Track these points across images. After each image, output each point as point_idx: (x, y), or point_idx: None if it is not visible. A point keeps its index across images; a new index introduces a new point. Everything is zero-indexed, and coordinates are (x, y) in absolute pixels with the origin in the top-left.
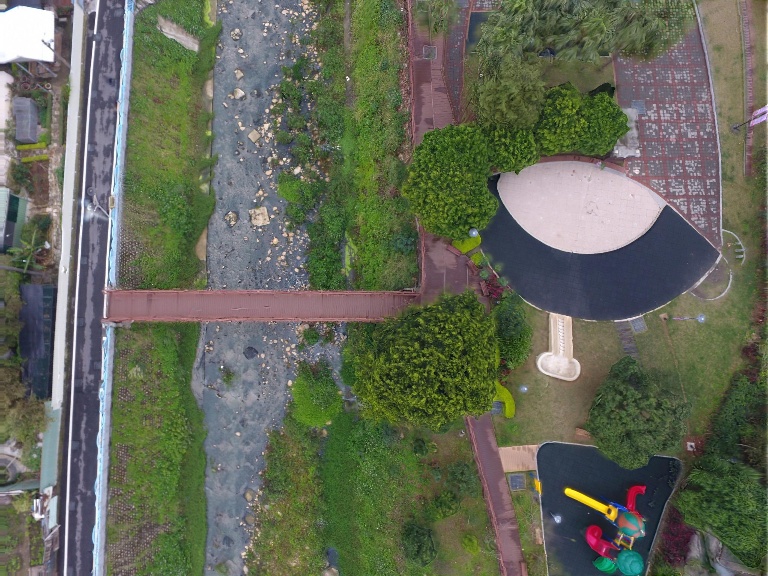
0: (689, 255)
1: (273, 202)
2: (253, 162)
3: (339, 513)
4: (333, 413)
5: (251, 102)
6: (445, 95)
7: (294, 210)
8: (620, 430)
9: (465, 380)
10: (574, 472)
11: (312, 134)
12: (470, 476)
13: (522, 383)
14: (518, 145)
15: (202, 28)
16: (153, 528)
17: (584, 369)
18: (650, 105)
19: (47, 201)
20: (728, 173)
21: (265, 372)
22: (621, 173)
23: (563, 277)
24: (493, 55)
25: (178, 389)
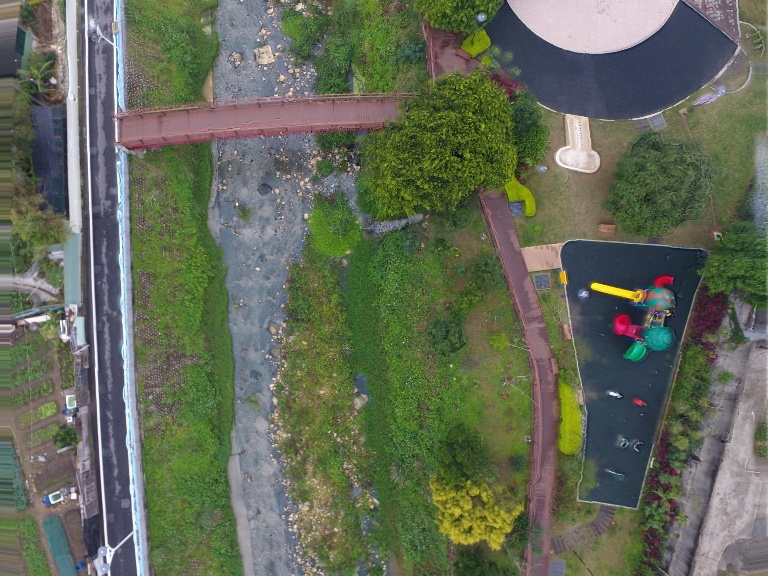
0: (706, 49)
1: (276, 41)
2: (253, 2)
3: (364, 339)
4: (351, 242)
5: None
6: None
7: (298, 43)
8: (645, 193)
9: (484, 140)
10: (599, 268)
11: None
12: (494, 267)
13: (541, 181)
14: None
15: None
16: (180, 358)
17: (604, 162)
18: None
19: (51, 39)
20: None
21: (280, 208)
22: None
23: (577, 79)
24: None
25: (195, 226)
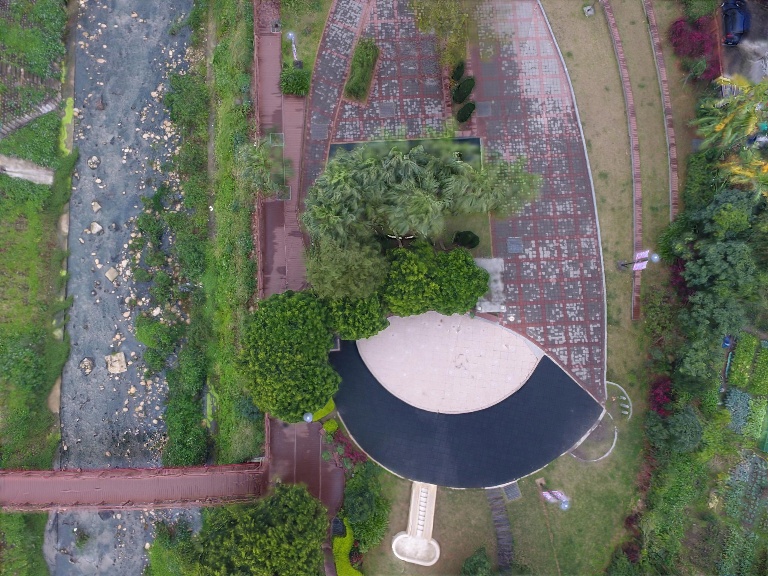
0: (569, 412)
1: (132, 346)
2: (110, 303)
3: None
4: None
5: (109, 236)
6: (300, 240)
7: (150, 358)
8: None
9: None
10: None
11: (173, 270)
12: None
13: (378, 566)
14: (358, 316)
15: (56, 158)
16: None
17: (445, 550)
18: (528, 242)
19: None
20: (614, 316)
21: (121, 534)
22: (493, 322)
23: (428, 440)
24: (314, 232)
25: (26, 557)
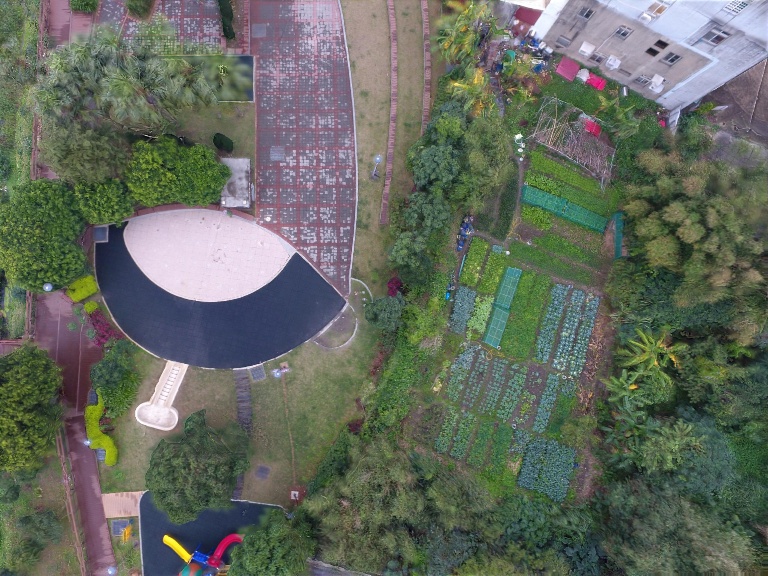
0: (314, 303)
1: None
2: None
3: None
4: None
5: None
6: None
7: None
8: (156, 487)
9: None
10: None
11: None
12: (49, 524)
13: (125, 431)
14: (98, 200)
15: None
16: None
17: (185, 418)
18: (289, 151)
19: None
20: (363, 220)
21: None
22: (250, 221)
23: (184, 325)
24: None
25: None
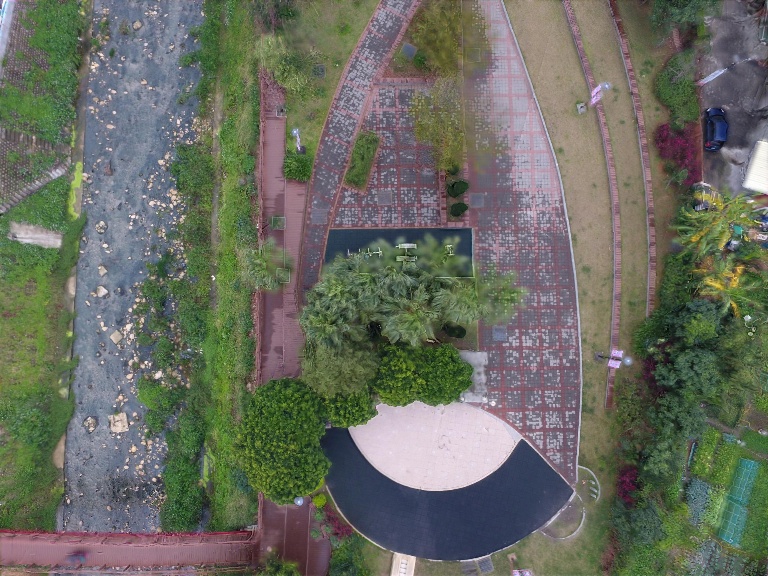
0: (541, 492)
1: (133, 407)
2: (114, 364)
3: None
4: None
5: (114, 300)
6: (297, 322)
7: (151, 421)
8: None
9: None
10: None
11: (175, 336)
12: None
13: None
14: (349, 409)
15: (64, 223)
16: None
17: None
18: (512, 331)
19: None
20: (589, 404)
21: None
22: (475, 406)
23: (410, 515)
24: (311, 338)
25: None
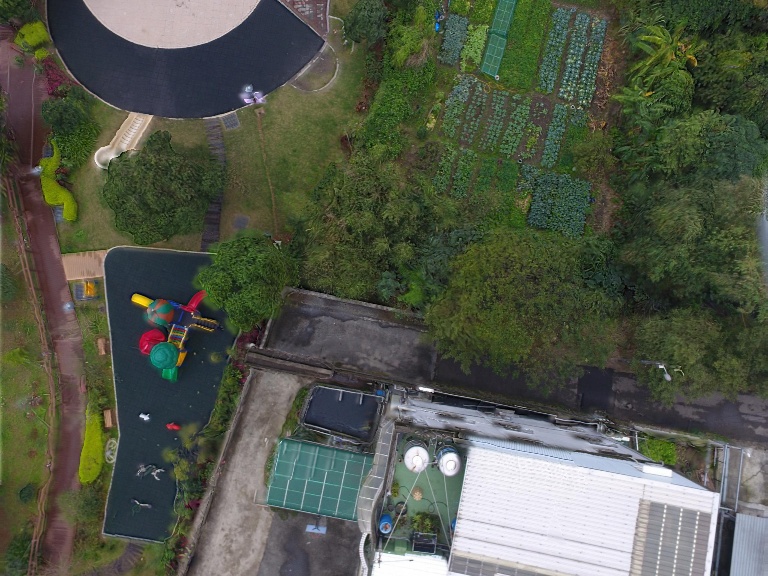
0: (290, 45)
1: None
2: None
3: None
4: None
5: None
6: None
7: None
8: (115, 194)
9: None
10: (144, 277)
11: None
12: (2, 274)
13: (85, 182)
14: None
15: None
16: None
17: None
18: None
19: None
20: None
21: None
22: None
23: (147, 74)
24: None
25: None
